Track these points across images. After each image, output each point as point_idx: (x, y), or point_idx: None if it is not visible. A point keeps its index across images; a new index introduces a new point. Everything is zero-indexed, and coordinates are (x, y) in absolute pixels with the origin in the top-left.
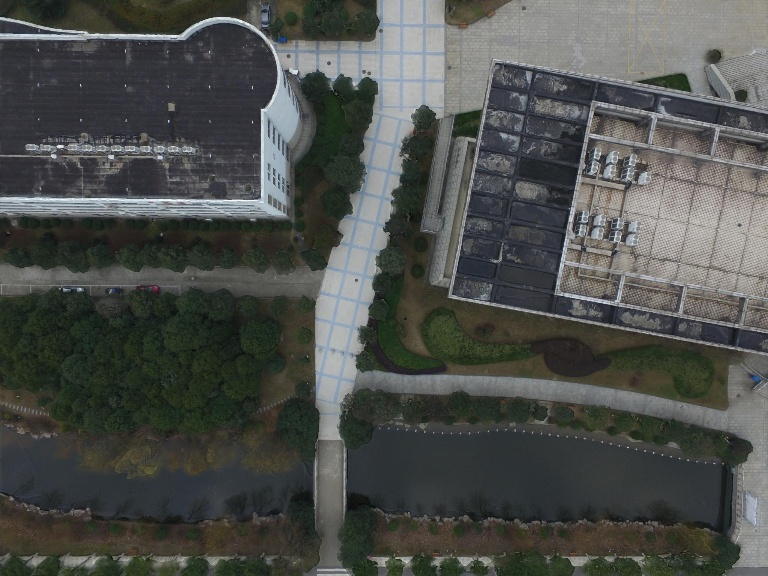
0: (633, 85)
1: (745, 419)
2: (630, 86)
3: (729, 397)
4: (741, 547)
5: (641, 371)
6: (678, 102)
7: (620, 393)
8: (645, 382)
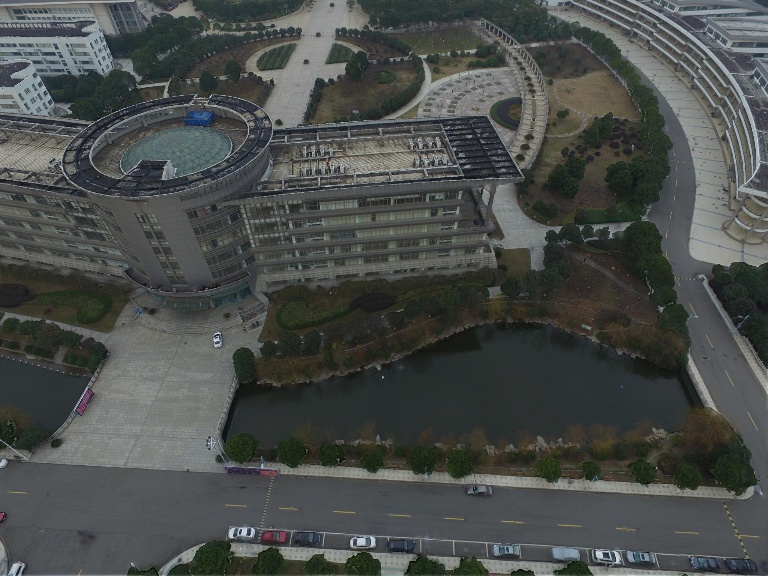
0: (7, 113)
1: (121, 339)
2: (8, 114)
3: (116, 325)
4: (64, 443)
5: (56, 304)
6: (30, 120)
7: (34, 319)
8: (57, 312)
